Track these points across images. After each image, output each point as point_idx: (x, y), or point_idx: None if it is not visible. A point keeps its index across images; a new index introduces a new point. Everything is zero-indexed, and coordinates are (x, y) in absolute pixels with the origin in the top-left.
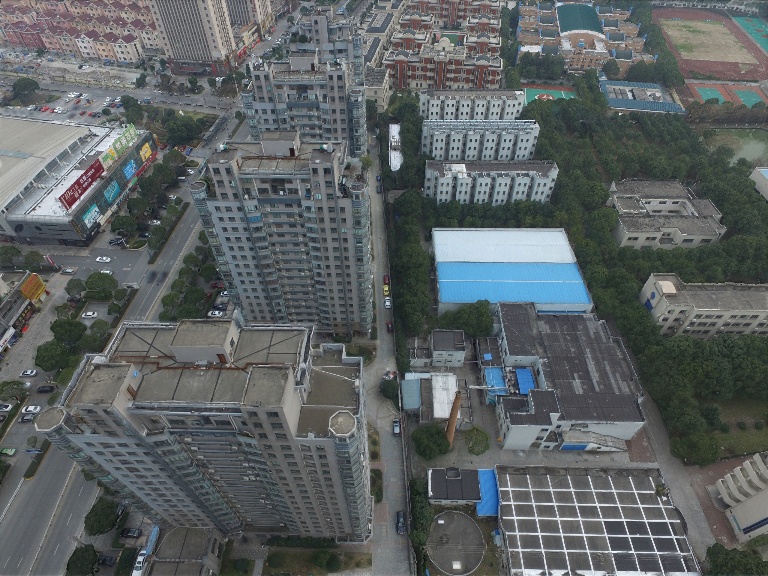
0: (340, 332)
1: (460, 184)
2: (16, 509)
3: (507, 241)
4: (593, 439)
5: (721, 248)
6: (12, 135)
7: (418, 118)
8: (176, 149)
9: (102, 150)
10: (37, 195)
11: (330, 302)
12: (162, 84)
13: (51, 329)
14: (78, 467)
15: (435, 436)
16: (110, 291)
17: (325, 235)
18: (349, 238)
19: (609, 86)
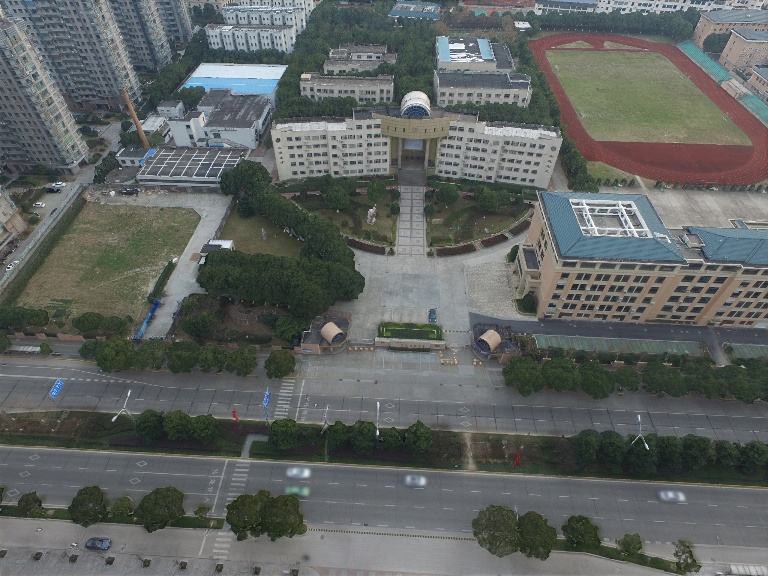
0: (112, 105)
1: (224, 36)
2: None
3: (246, 69)
4: (226, 141)
5: (373, 70)
6: None
7: None
8: None
9: None
10: None
11: (96, 76)
12: None
13: None
14: None
15: (131, 134)
16: None
17: (72, 16)
18: (86, 19)
19: (401, 4)
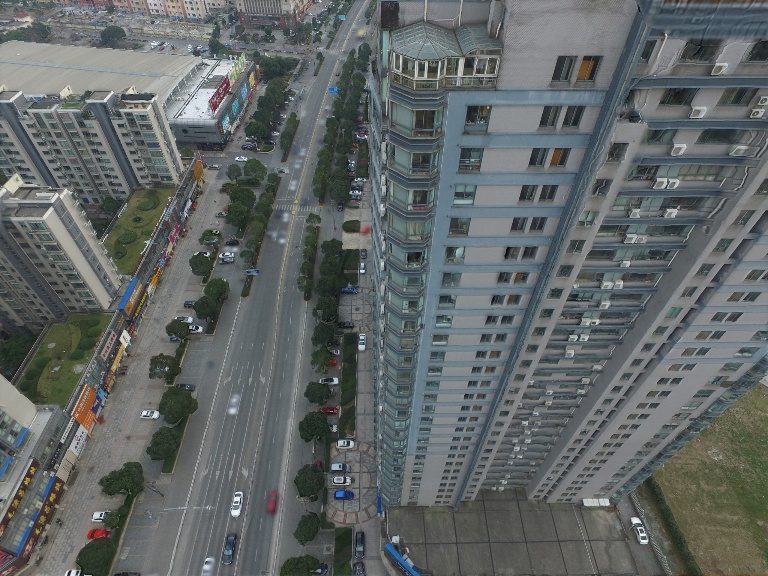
0: None
1: None
2: (244, 316)
3: None
4: None
5: None
6: (136, 61)
7: None
8: None
9: (219, 75)
10: (177, 105)
11: None
12: (236, 35)
13: (232, 195)
14: (283, 290)
15: None
16: (263, 176)
17: None
18: None
19: None
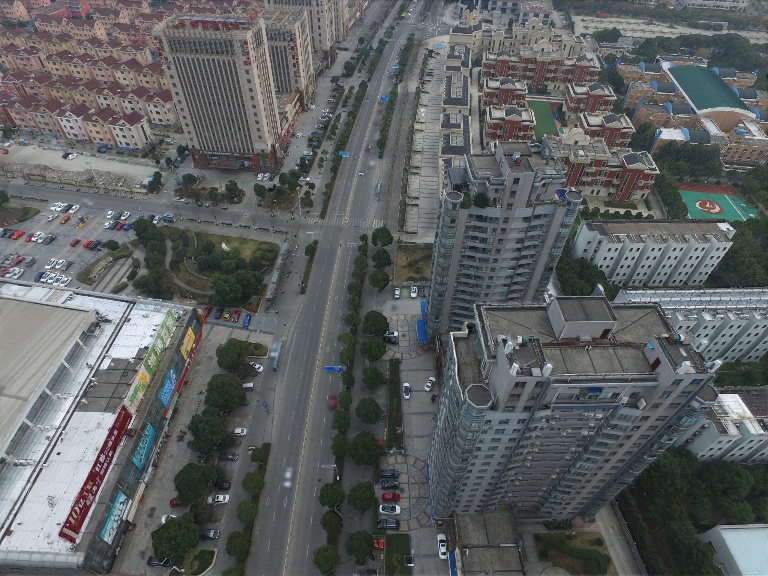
0: None
1: (748, 440)
2: None
3: None
4: None
5: None
6: None
7: (583, 264)
8: (227, 318)
9: (121, 357)
10: (13, 486)
11: None
12: (185, 187)
13: None
14: None
15: None
16: None
17: None
18: None
19: None
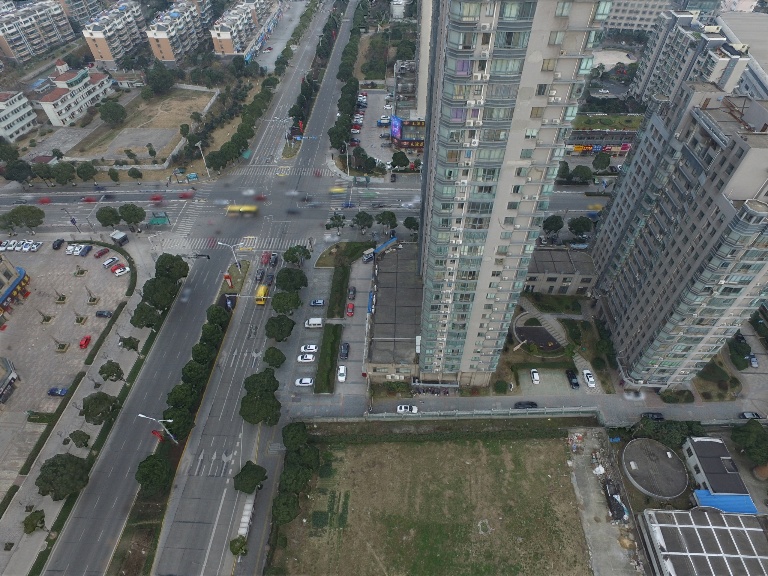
0: None
1: None
2: (566, 196)
3: None
4: None
5: None
6: None
7: None
8: None
9: None
10: None
11: None
12: None
13: None
14: None
15: (767, 442)
16: None
17: None
18: None
19: None
